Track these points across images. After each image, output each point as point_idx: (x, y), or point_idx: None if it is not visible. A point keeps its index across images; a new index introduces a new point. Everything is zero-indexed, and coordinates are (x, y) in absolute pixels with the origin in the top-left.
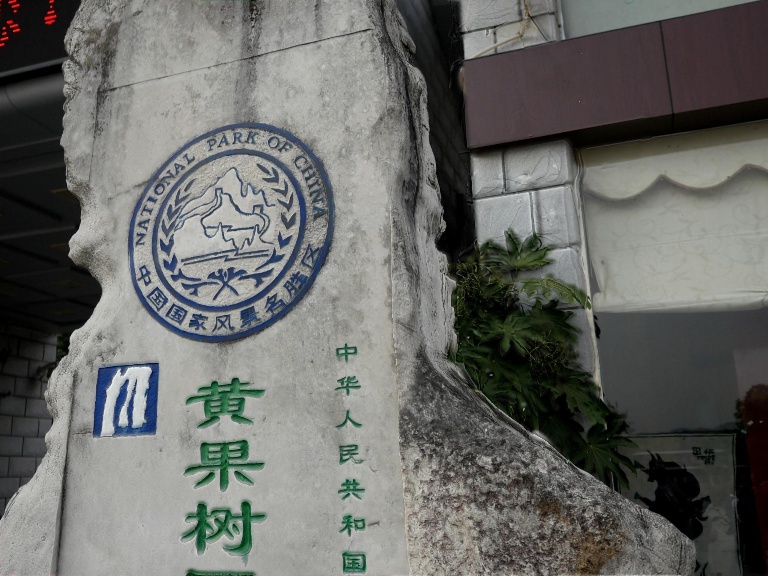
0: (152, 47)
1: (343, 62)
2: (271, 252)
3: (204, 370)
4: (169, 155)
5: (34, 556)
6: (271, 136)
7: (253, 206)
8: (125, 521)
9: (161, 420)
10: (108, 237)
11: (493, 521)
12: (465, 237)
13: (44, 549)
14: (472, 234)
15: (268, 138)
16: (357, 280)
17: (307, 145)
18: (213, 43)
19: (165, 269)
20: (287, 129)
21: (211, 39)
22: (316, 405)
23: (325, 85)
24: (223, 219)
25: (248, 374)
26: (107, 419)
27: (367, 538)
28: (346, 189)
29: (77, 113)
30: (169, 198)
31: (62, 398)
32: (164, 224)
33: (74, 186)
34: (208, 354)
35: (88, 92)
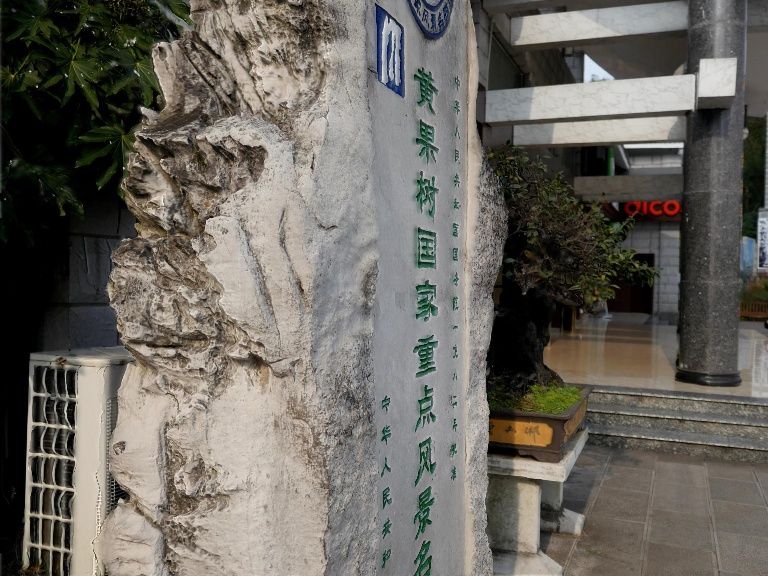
0: None
1: None
2: None
3: None
4: None
5: (363, 194)
6: None
7: None
8: (395, 174)
9: (406, 86)
10: None
11: (496, 212)
12: None
13: (369, 188)
14: None
15: None
16: None
17: None
18: None
19: None
20: None
21: None
22: None
23: None
24: None
25: None
26: (384, 65)
27: (459, 215)
28: None
29: None
30: None
31: (356, 18)
32: None
33: None
34: None
35: None
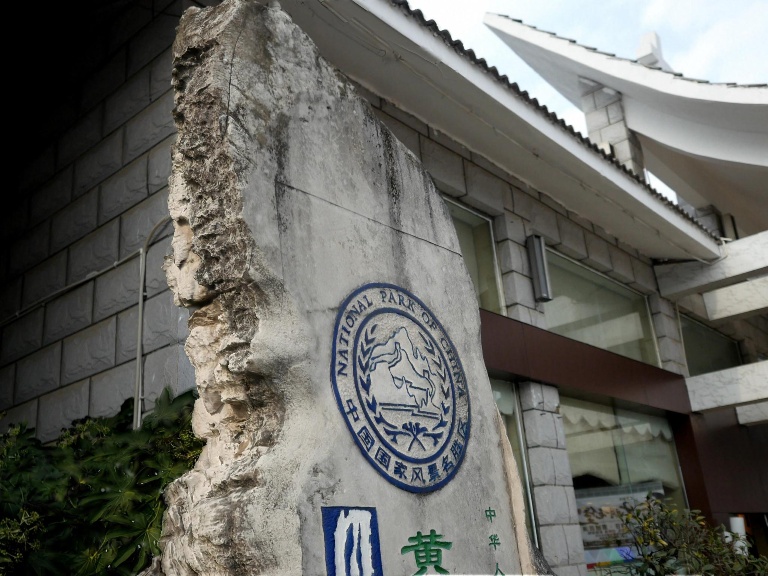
0: (322, 166)
1: (454, 273)
2: (440, 416)
3: (411, 519)
4: (351, 289)
5: None
6: (423, 311)
7: (423, 370)
8: None
9: (386, 570)
10: (311, 355)
11: None
12: (178, 378)
13: None
14: (188, 378)
15: (422, 312)
16: (488, 456)
17: (446, 331)
18: (370, 198)
19: (368, 408)
20: (432, 310)
21: (368, 193)
22: (482, 558)
23: (447, 285)
24: (405, 374)
25: (440, 527)
26: (340, 568)
27: None
28: (473, 379)
29: (257, 191)
30: (360, 335)
31: (286, 540)
32: (361, 360)
33: (262, 277)
34: (412, 504)
35: (265, 174)
